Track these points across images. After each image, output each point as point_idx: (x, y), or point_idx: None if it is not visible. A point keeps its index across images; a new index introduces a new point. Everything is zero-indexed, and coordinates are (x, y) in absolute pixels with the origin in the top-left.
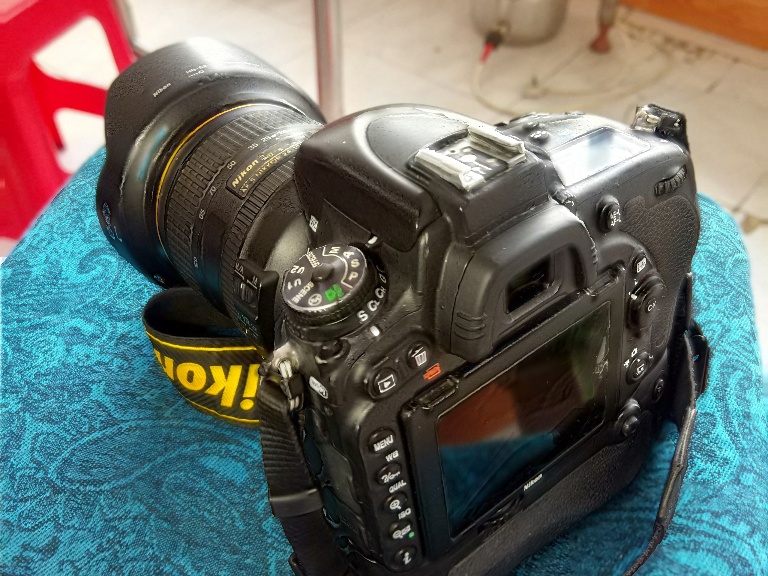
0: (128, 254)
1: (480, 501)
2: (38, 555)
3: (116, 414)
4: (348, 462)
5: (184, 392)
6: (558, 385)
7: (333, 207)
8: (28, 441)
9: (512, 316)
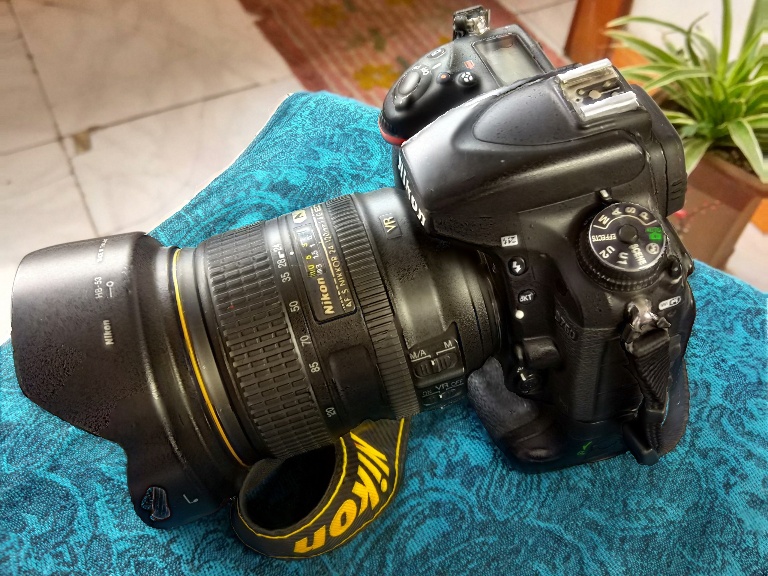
0: (202, 507)
1: None
2: None
3: None
4: (679, 335)
5: (335, 543)
6: None
7: (536, 209)
8: None
9: None
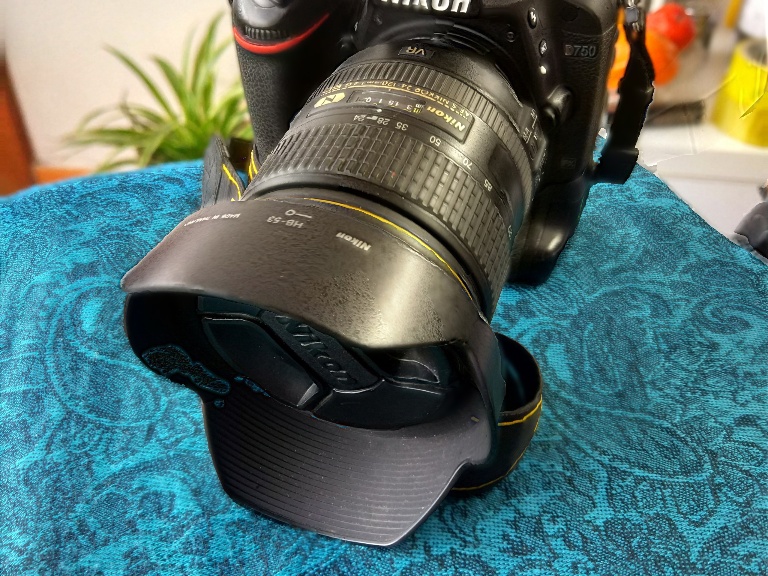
0: None
1: None
2: (760, 424)
3: (603, 476)
4: None
5: None
6: None
7: None
8: (711, 526)
9: None
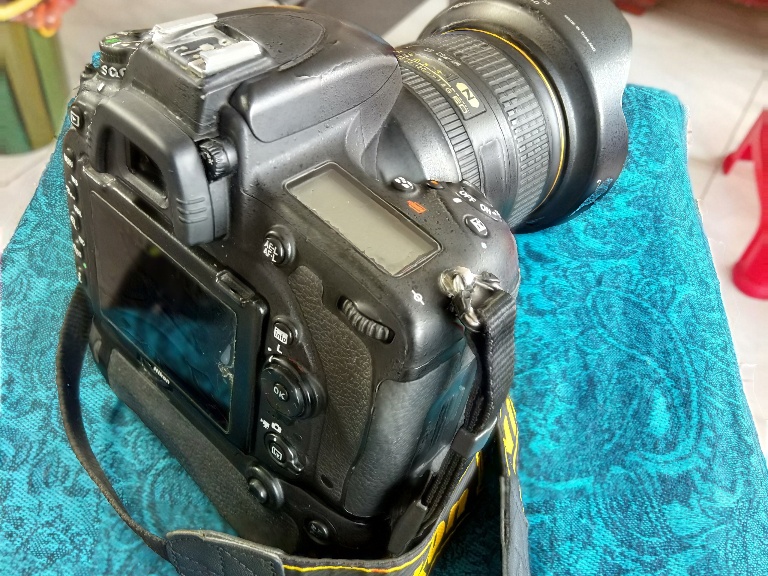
0: None
1: (138, 331)
2: None
3: None
4: None
5: None
6: (185, 321)
7: None
8: None
9: (130, 176)
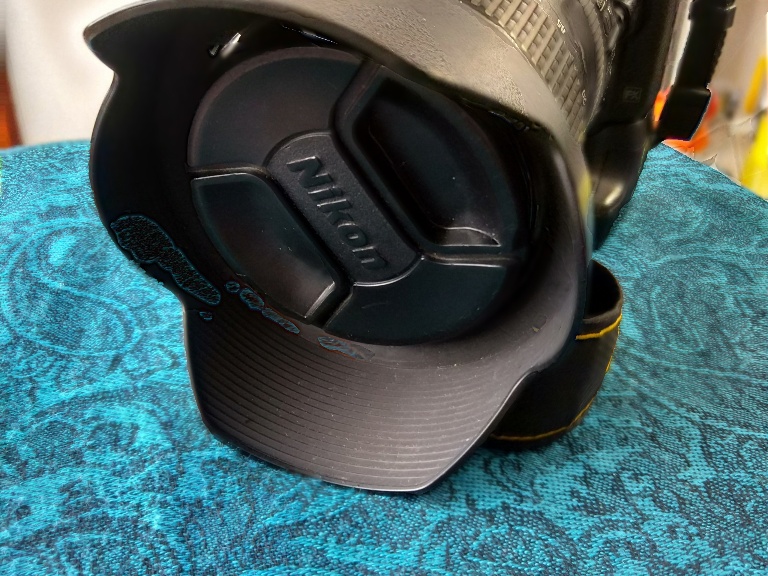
0: None
1: None
2: None
3: (695, 433)
4: None
5: None
6: None
7: None
8: None
9: None
